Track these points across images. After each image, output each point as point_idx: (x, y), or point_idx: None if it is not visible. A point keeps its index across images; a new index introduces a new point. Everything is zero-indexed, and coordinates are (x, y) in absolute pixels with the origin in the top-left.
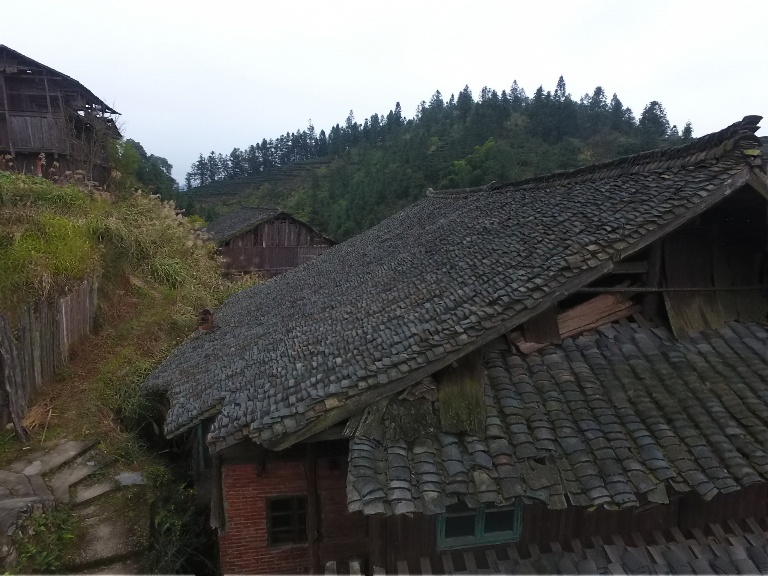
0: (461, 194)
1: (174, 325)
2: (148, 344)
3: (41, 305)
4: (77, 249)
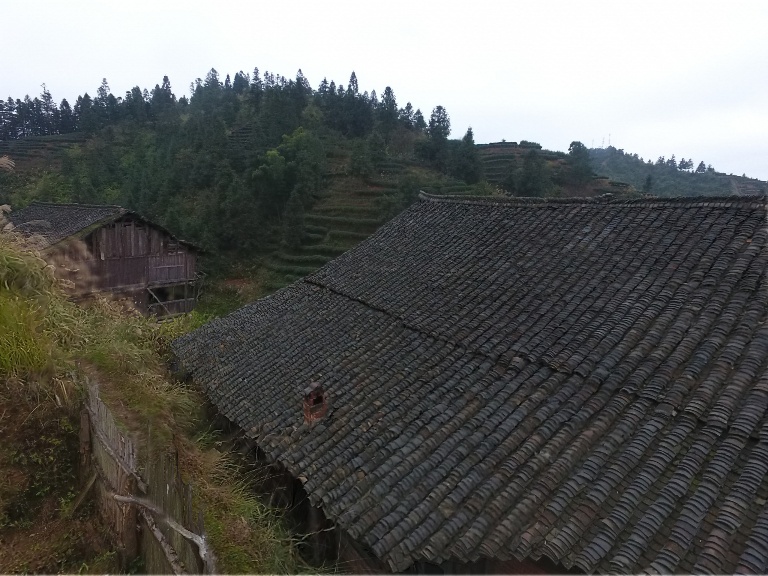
0: (529, 203)
1: (173, 411)
2: (197, 459)
3: (171, 465)
4: (13, 315)
